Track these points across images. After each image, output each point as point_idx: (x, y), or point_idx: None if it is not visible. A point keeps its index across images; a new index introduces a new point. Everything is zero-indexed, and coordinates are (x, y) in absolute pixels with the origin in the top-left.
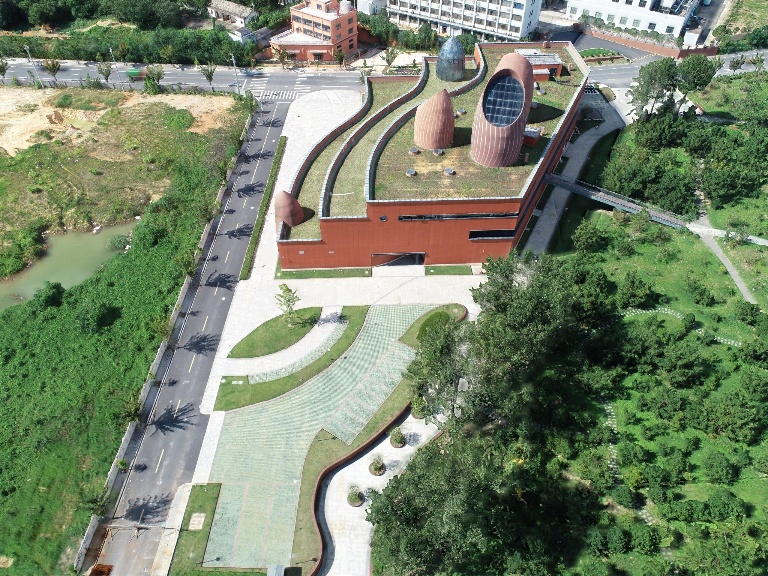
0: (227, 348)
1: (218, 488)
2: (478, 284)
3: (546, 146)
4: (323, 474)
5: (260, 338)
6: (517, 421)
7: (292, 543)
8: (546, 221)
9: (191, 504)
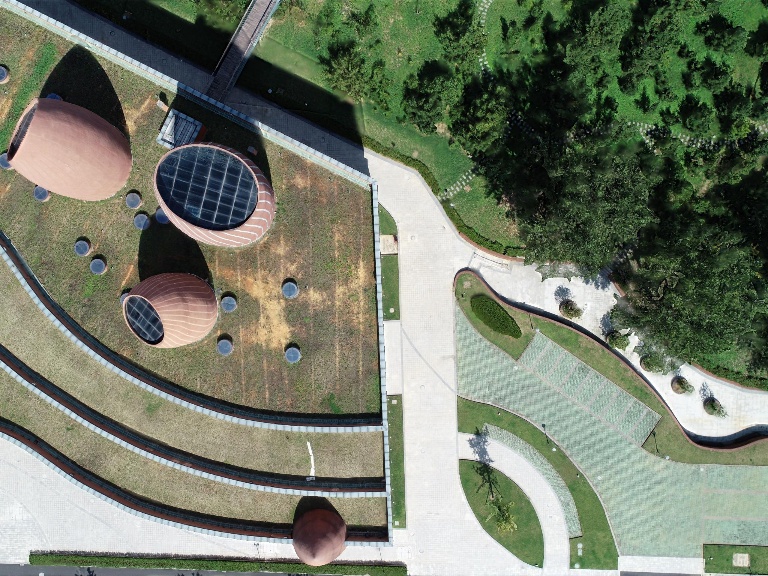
0: (526, 571)
1: (709, 547)
2: (417, 249)
3: (205, 107)
4: (693, 442)
5: (515, 533)
6: (673, 239)
7: (764, 467)
8: (279, 127)
9: (725, 570)
